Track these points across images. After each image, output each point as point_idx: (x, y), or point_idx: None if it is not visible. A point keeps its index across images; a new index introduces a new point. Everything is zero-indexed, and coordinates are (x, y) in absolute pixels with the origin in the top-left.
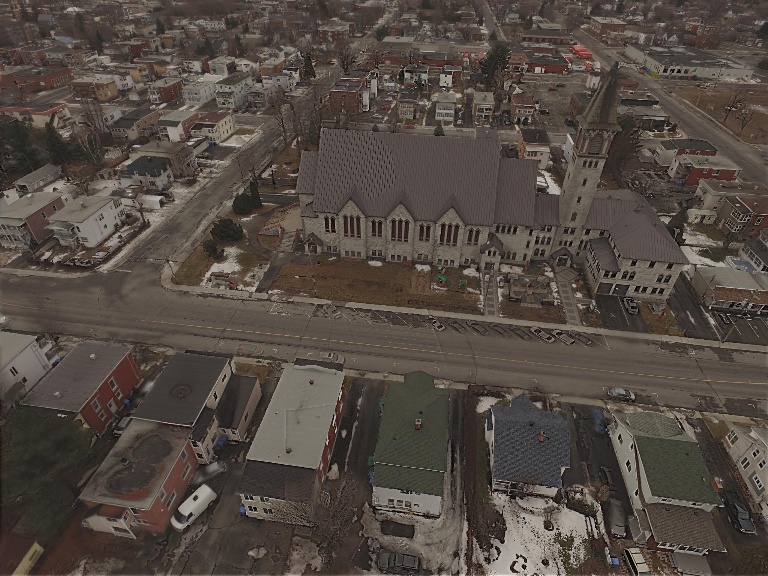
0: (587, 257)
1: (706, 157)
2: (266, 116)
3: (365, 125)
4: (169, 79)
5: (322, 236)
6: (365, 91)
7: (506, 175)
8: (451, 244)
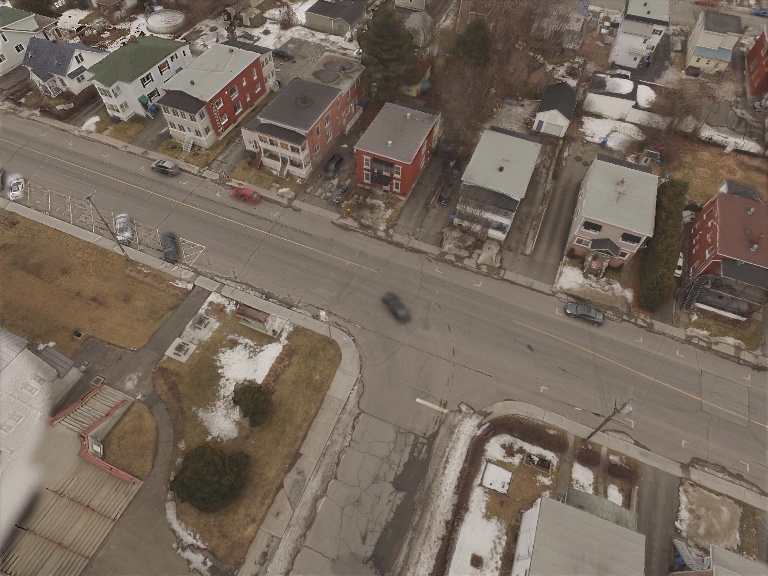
0: None
1: None
2: None
3: None
4: None
5: None
6: None
7: None
8: None
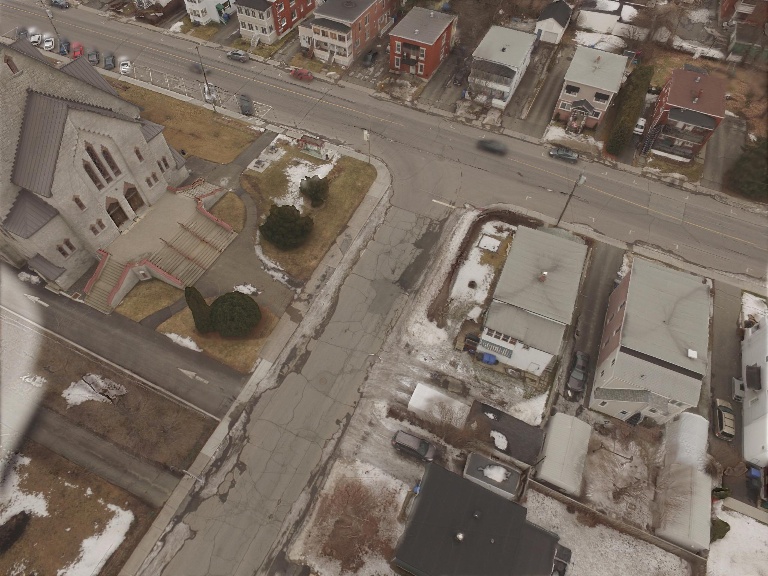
0: None
1: None
2: None
3: None
4: None
5: None
6: None
7: None
8: None
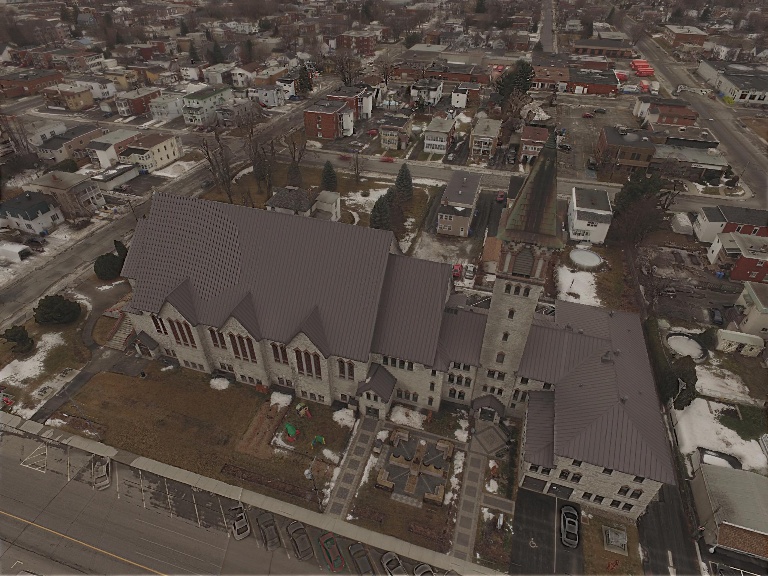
0: (525, 414)
1: (766, 240)
2: (230, 137)
3: (337, 155)
4: (144, 89)
5: (155, 336)
6: (346, 113)
7: (401, 282)
8: (314, 376)
